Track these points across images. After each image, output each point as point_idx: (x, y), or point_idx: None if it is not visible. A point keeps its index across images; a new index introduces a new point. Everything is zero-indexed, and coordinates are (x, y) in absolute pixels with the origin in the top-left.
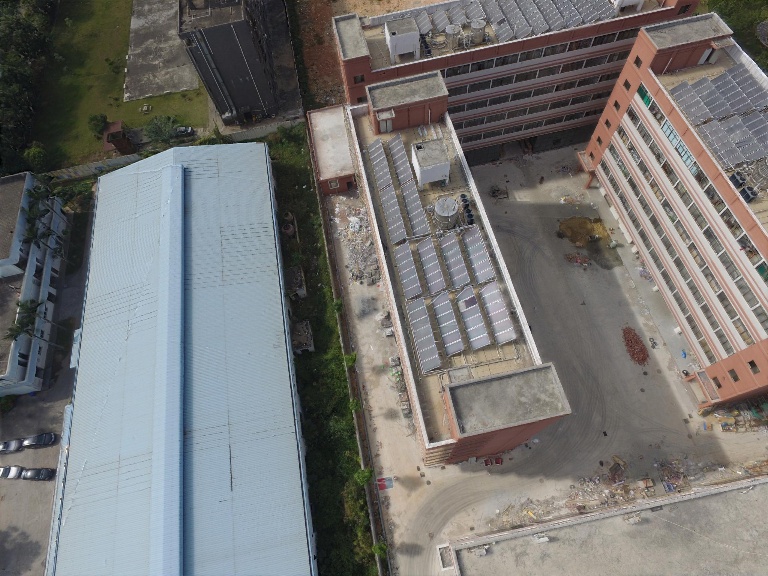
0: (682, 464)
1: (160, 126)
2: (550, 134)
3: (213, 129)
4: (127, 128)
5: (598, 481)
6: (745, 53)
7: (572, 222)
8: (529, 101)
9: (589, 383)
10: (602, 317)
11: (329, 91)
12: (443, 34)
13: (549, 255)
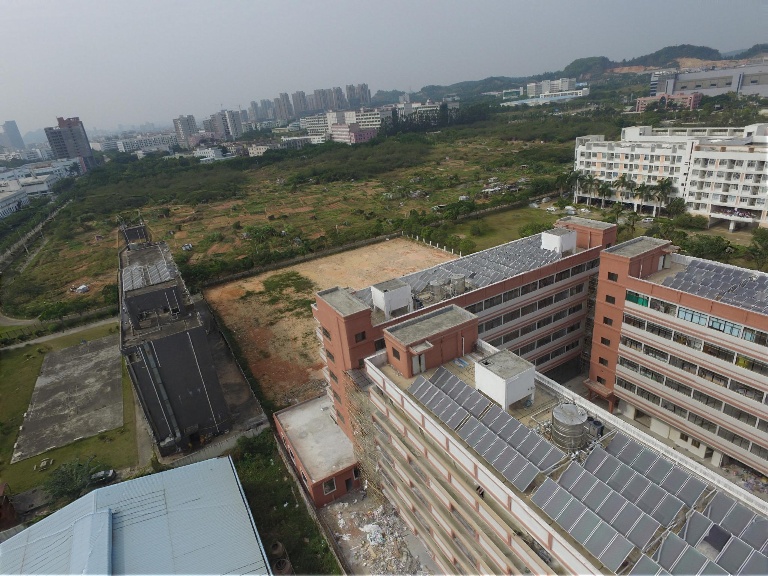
0: None
1: (69, 474)
2: None
3: (150, 459)
4: (10, 495)
5: None
6: None
7: None
8: (519, 341)
9: None
10: None
11: (290, 393)
12: (424, 293)
13: None
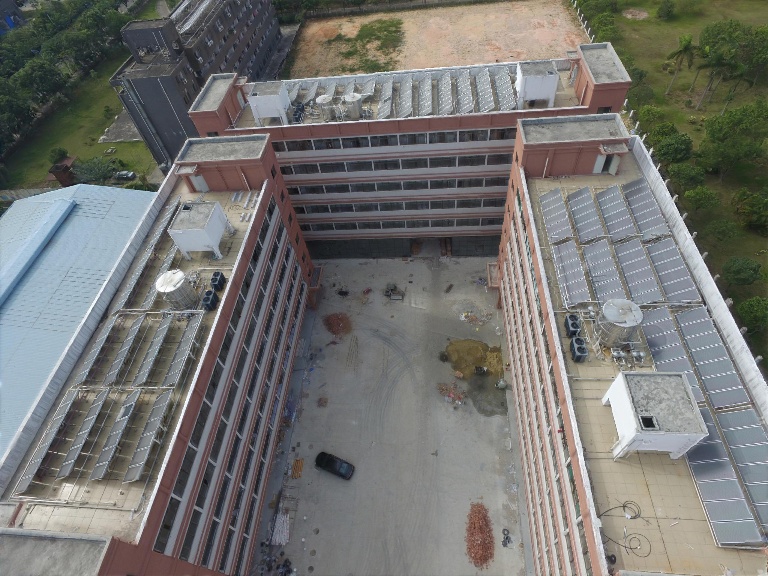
0: None
1: (97, 165)
2: (468, 237)
3: None
4: None
5: None
6: None
7: (462, 345)
8: (428, 193)
9: (395, 571)
10: (451, 479)
11: None
12: None
13: (419, 379)
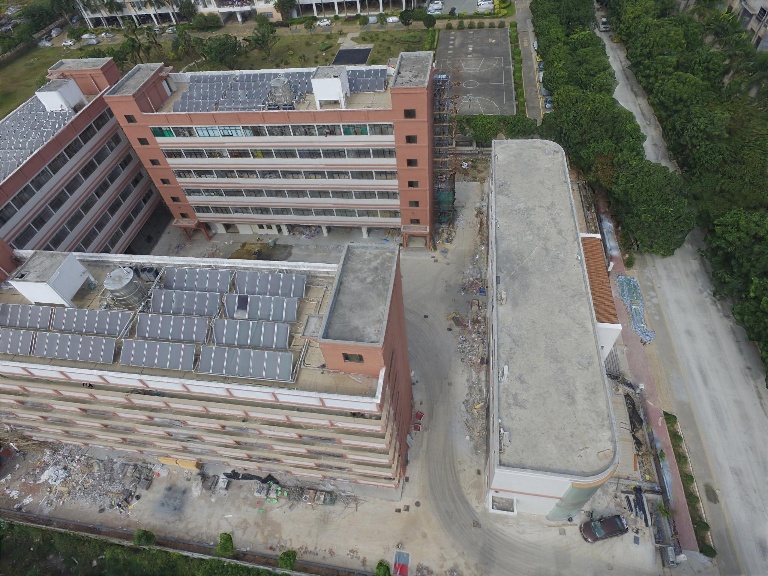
0: (467, 277)
1: None
2: (137, 237)
3: None
4: None
5: (463, 338)
6: (186, 73)
7: None
8: (87, 221)
9: None
10: None
11: None
12: None
13: None
